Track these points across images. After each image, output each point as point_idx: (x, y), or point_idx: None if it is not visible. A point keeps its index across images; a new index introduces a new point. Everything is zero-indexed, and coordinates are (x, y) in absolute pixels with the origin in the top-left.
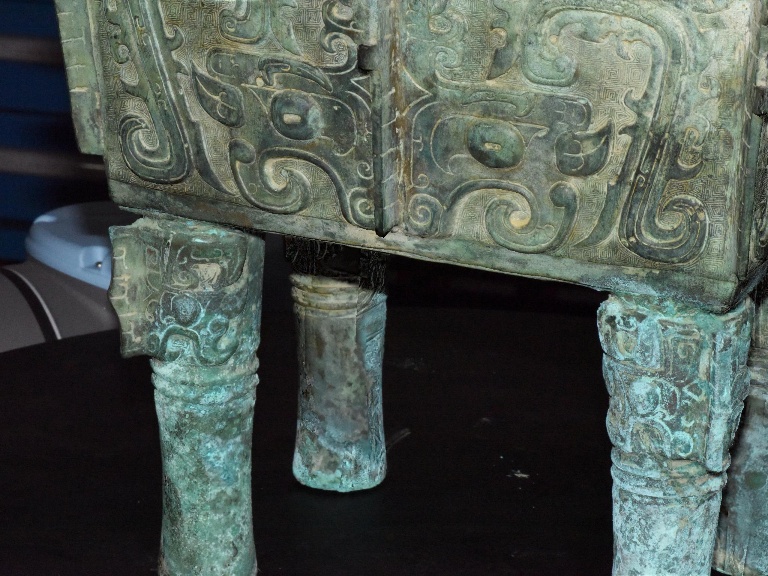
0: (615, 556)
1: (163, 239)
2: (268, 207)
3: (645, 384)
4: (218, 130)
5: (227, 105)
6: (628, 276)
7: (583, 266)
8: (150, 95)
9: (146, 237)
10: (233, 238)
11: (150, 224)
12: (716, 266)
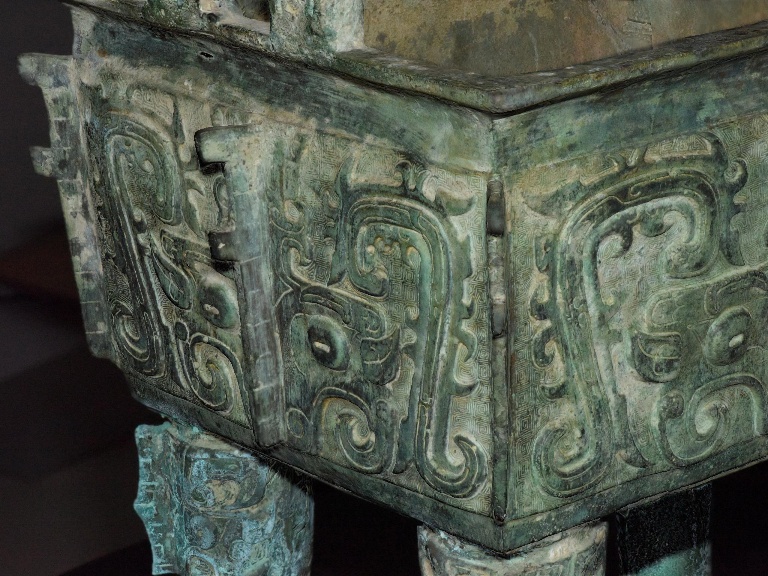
0: None
1: None
2: None
3: None
4: None
5: None
6: None
7: None
8: None
9: None
10: None
11: None
12: None
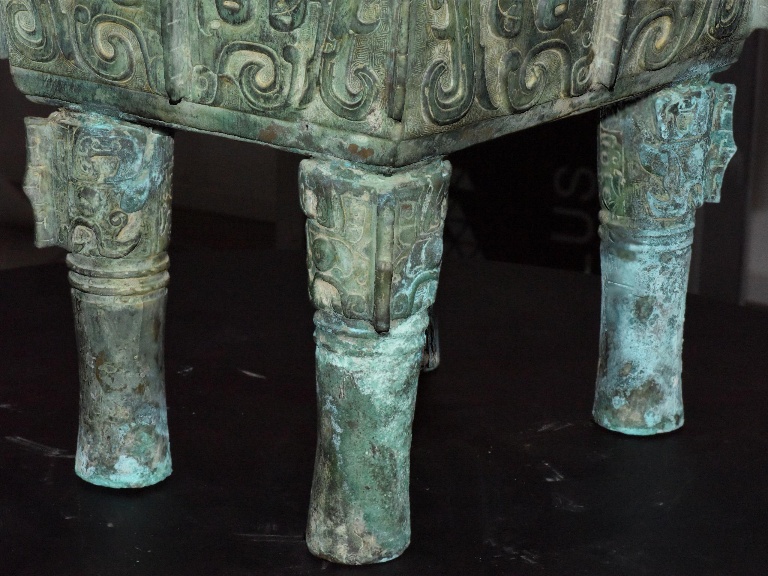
0: (649, 316)
1: (424, 186)
2: (521, 108)
3: (701, 149)
4: (497, 47)
5: (513, 17)
6: (700, 61)
7: (680, 65)
8: (456, 33)
9: (402, 194)
10: (447, 164)
11: (402, 179)
12: (743, 28)
